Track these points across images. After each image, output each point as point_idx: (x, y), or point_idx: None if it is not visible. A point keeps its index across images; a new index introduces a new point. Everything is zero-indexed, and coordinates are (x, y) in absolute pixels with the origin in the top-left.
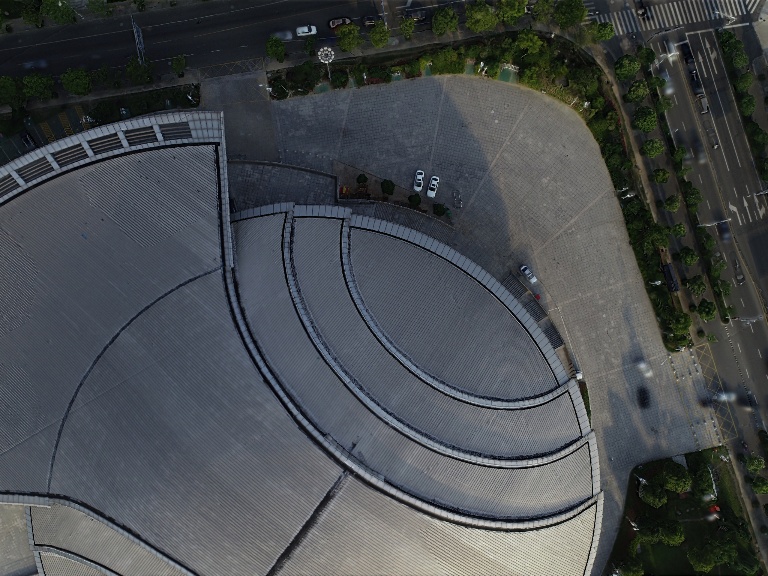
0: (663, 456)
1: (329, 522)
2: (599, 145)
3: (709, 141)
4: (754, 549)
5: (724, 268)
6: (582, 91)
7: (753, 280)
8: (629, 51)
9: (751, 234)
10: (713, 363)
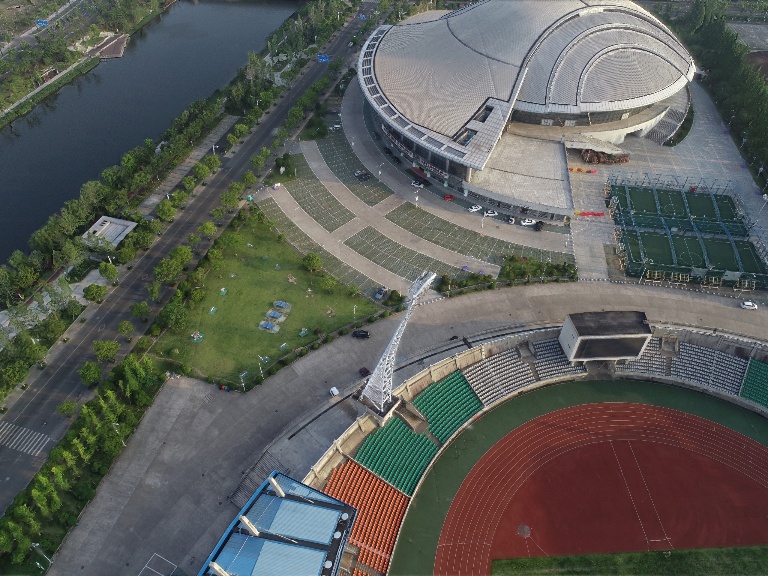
0: None
1: None
2: (446, 10)
3: None
4: None
5: None
6: (426, 1)
7: None
8: None
9: None
10: None
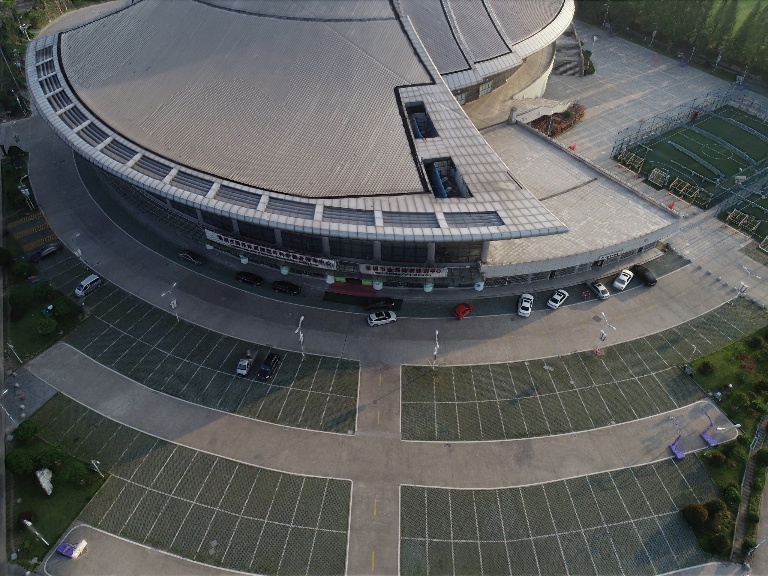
0: None
1: None
2: (93, 5)
3: None
4: None
5: None
6: None
7: None
8: None
9: None
10: None
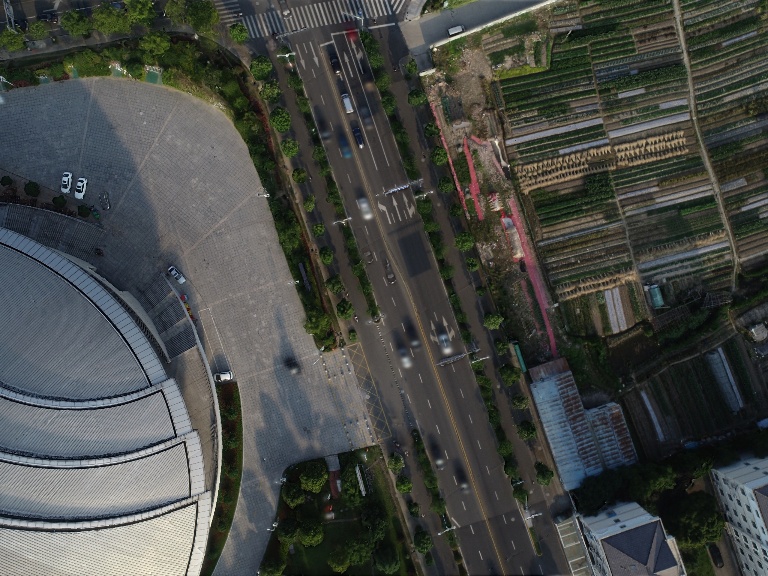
0: (316, 456)
1: None
2: (247, 146)
3: (356, 141)
4: (409, 549)
5: (363, 267)
6: (216, 92)
7: (403, 279)
8: (275, 52)
9: (401, 233)
10: (365, 362)
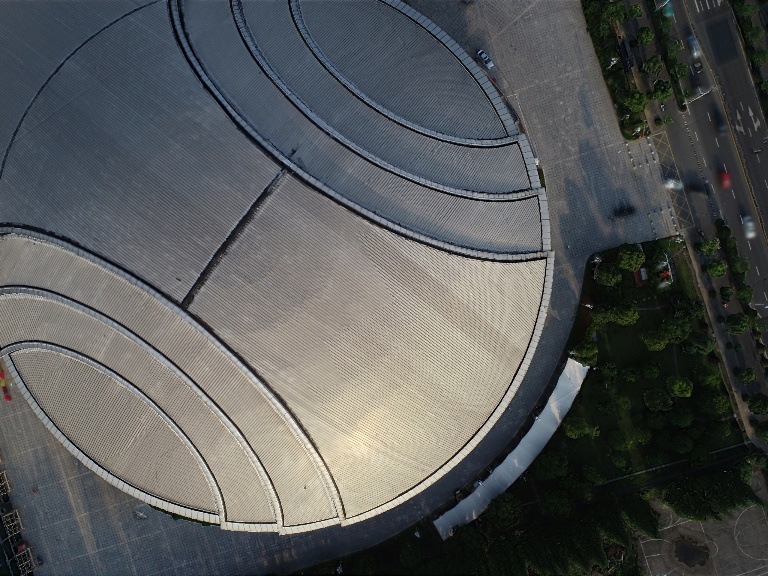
0: (620, 244)
1: (266, 218)
2: None
3: None
4: None
5: (680, 49)
6: None
7: (711, 68)
8: None
9: (709, 22)
10: (670, 152)
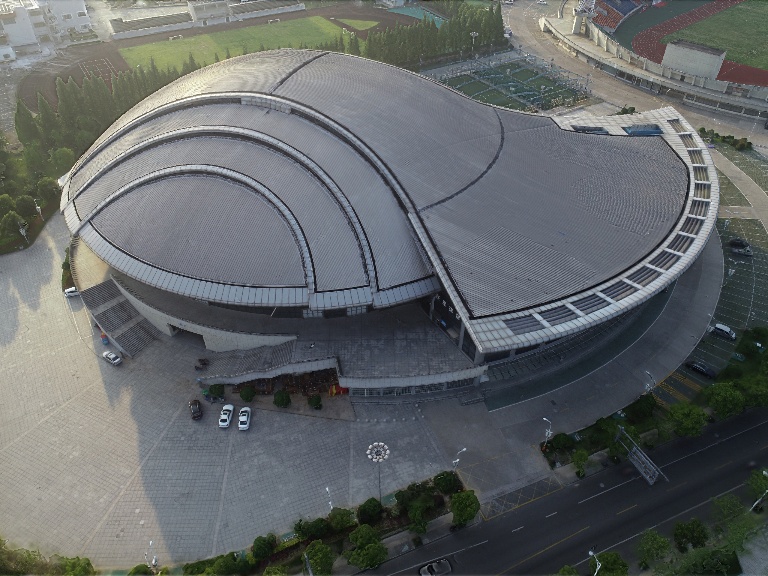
0: None
1: None
2: None
3: None
4: None
5: None
6: None
7: None
8: None
9: None
10: None
